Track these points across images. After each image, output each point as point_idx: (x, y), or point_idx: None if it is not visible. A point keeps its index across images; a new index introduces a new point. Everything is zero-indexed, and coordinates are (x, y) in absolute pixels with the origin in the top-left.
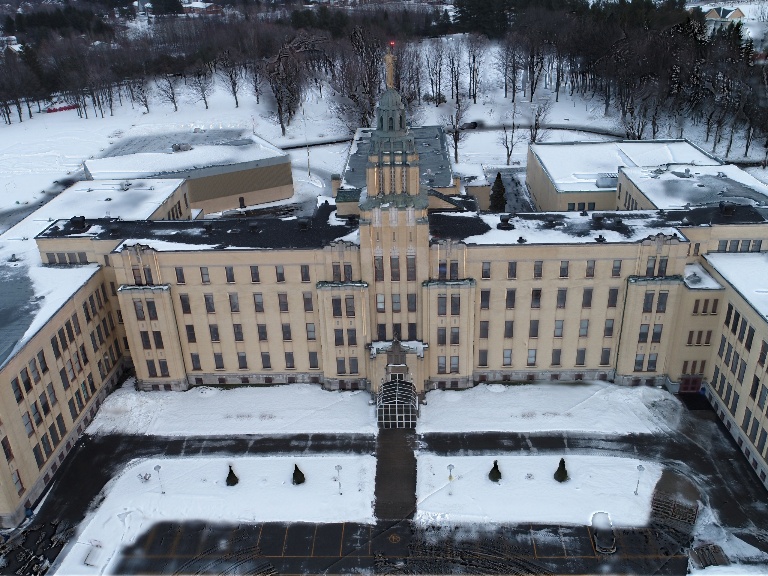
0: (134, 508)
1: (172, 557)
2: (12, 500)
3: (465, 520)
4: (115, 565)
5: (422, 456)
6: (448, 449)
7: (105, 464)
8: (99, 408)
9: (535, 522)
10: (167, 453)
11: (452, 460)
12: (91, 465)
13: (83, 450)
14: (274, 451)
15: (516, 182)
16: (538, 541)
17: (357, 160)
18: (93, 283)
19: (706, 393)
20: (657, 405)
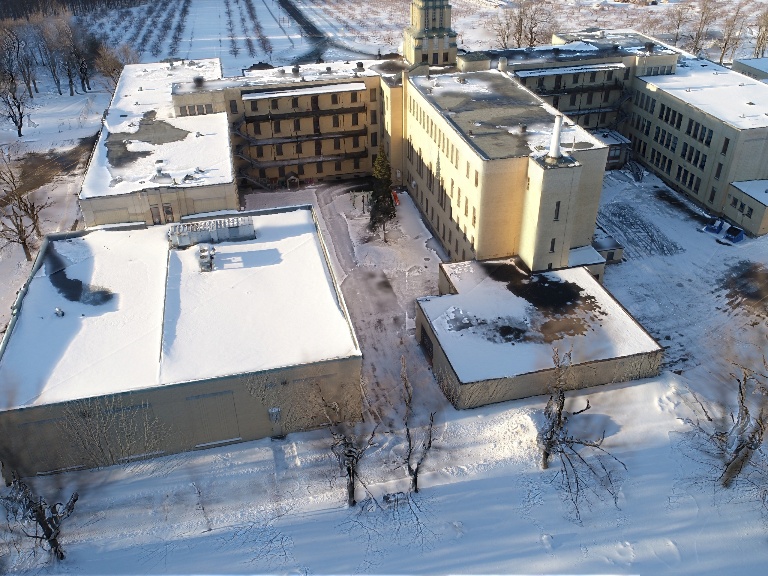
0: None
1: None
2: None
3: None
4: None
5: None
6: None
7: None
8: None
9: None
10: None
11: None
12: None
13: None
14: None
15: (384, 417)
16: None
17: (527, 96)
18: None
19: None
20: None
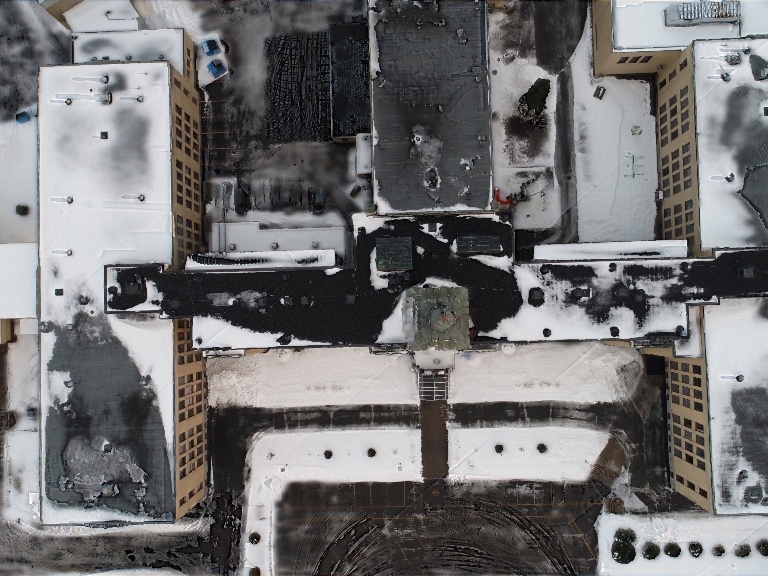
0: (272, 476)
1: (307, 509)
2: (201, 496)
3: (478, 479)
4: (276, 515)
5: (452, 432)
6: (469, 421)
7: (237, 438)
8: (207, 377)
9: (520, 479)
10: (276, 427)
11: (472, 433)
12: (228, 439)
13: (216, 424)
14: (350, 424)
15: None
16: (520, 494)
17: (382, 104)
18: (176, 340)
19: (666, 358)
20: (625, 370)
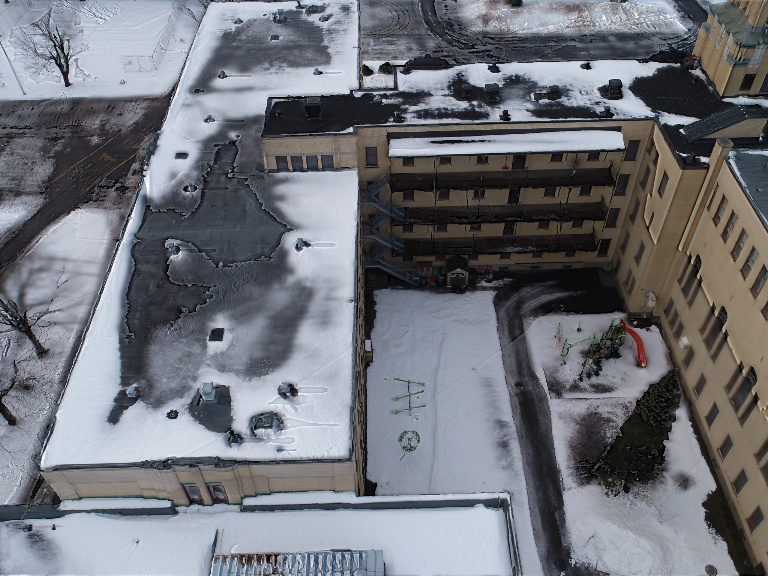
0: None
1: None
2: None
3: None
4: None
5: None
6: None
7: None
8: None
9: None
10: None
11: None
12: None
13: None
14: None
15: None
16: None
17: None
18: None
19: None
20: None
